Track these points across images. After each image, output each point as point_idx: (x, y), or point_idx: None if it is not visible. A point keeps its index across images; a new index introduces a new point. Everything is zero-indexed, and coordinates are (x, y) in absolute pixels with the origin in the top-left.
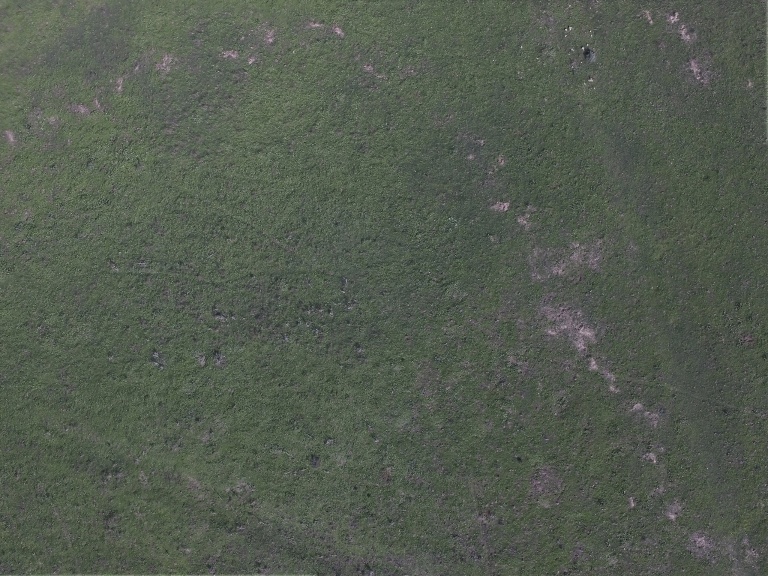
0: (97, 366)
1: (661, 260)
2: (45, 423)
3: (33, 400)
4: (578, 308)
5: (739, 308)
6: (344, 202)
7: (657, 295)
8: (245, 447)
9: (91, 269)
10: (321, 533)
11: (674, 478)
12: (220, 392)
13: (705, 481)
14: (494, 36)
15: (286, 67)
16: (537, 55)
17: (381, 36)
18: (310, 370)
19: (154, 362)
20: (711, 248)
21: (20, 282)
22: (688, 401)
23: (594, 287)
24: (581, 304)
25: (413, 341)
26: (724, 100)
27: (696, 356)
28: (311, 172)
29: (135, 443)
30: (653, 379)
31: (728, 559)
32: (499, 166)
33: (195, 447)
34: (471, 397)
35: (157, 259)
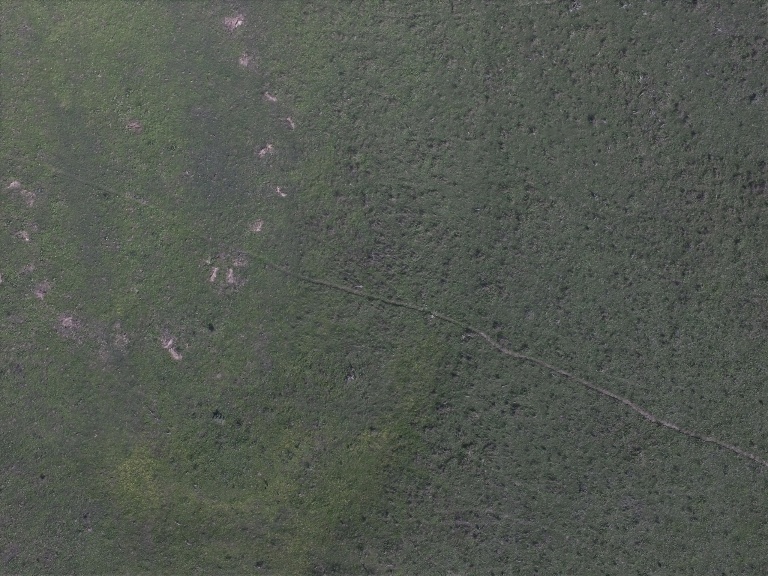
0: None
1: (57, 42)
2: None
3: None
4: None
5: (129, 94)
6: None
7: (50, 77)
8: None
9: None
10: None
11: (46, 257)
12: None
13: (78, 262)
14: None
15: None
16: None
17: None
18: None
19: None
20: (109, 34)
21: None
22: (71, 183)
23: None
24: None
25: None
26: None
27: (83, 140)
28: None
29: None
30: (34, 158)
31: (96, 341)
32: None
33: None
34: None
35: None
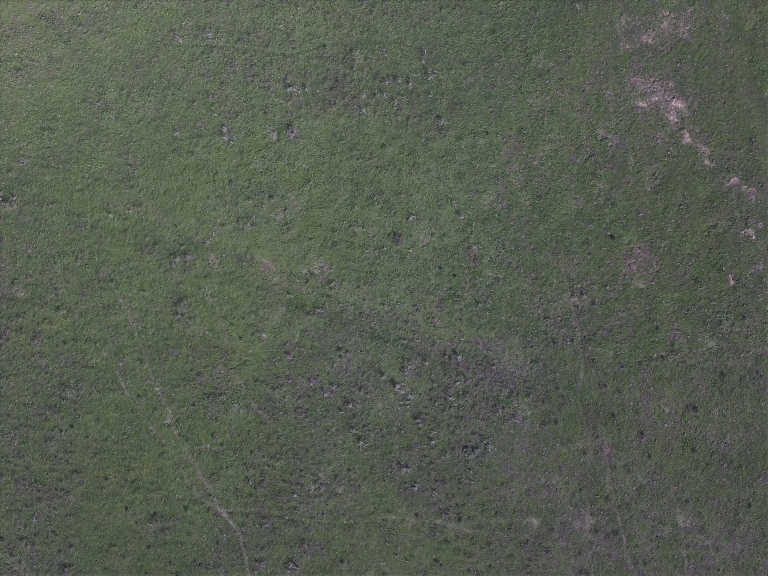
0: (161, 144)
1: (754, 30)
2: (107, 205)
3: (93, 181)
4: (669, 79)
5: None
6: None
7: (751, 66)
8: (322, 225)
9: (153, 42)
10: (405, 316)
11: None
12: (294, 168)
13: None
14: None
15: None
16: None
17: None
18: (390, 144)
19: (223, 137)
20: None
21: (76, 56)
22: None
23: (686, 57)
24: (672, 75)
25: (497, 113)
26: None
27: None
28: None
29: (204, 224)
30: (750, 152)
31: None
32: None
33: (269, 226)
34: (560, 172)
35: (223, 31)
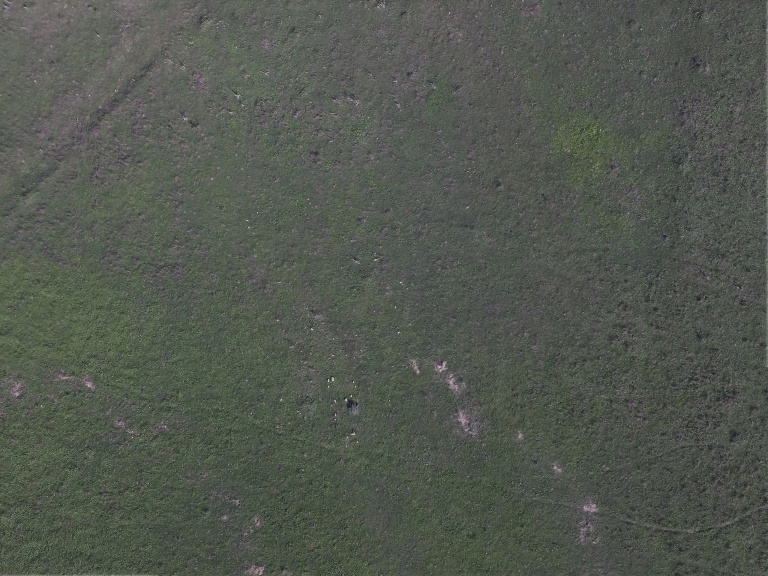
0: None
1: None
2: None
3: None
4: None
5: None
6: (90, 567)
7: None
8: None
9: None
10: None
11: None
12: None
13: None
14: (253, 387)
15: (33, 422)
16: (298, 408)
17: (134, 389)
18: None
19: None
20: None
21: None
22: None
23: None
24: None
25: None
26: (493, 453)
27: None
28: (57, 535)
29: None
30: None
31: None
32: (255, 527)
33: None
34: None
35: None
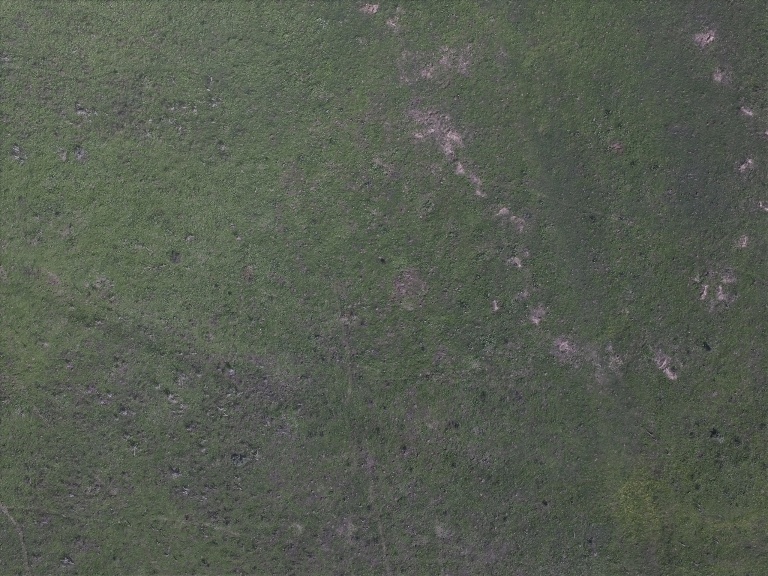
0: None
1: (532, 67)
2: None
3: None
4: (446, 112)
5: (608, 115)
6: (211, 1)
7: (527, 102)
8: (105, 242)
9: None
10: (181, 330)
11: (539, 283)
12: (81, 187)
13: (570, 286)
14: None
15: None
16: None
17: None
18: (172, 166)
19: (14, 156)
20: (582, 56)
21: None
22: (555, 207)
23: (462, 91)
24: (449, 108)
25: (278, 140)
26: None
27: (564, 163)
28: None
29: None
30: (520, 184)
31: (591, 364)
32: None
33: (55, 241)
34: (335, 198)
35: (20, 54)
